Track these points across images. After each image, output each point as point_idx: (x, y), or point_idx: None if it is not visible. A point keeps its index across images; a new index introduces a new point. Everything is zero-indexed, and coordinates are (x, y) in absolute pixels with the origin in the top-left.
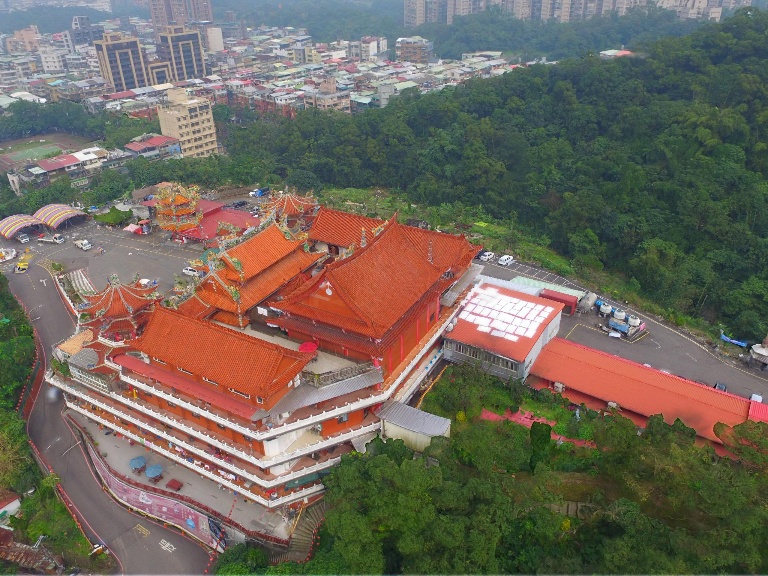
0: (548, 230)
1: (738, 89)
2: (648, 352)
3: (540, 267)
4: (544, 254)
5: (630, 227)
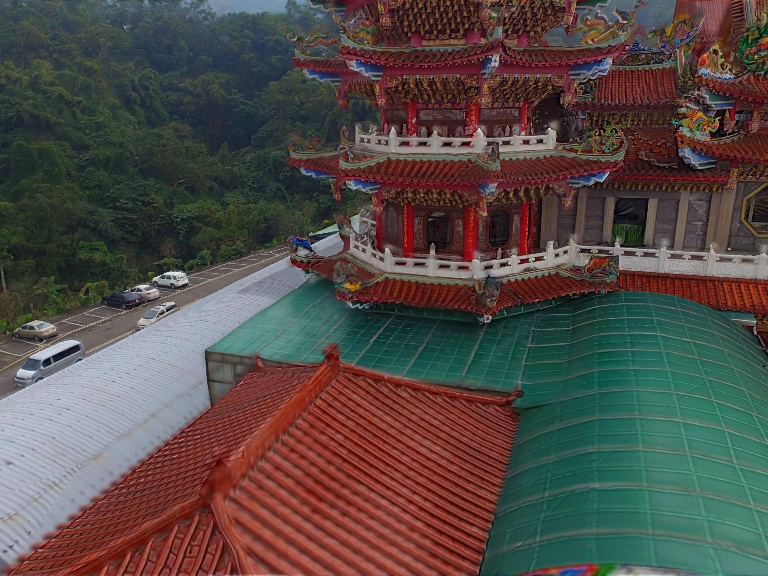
0: (8, 284)
1: (25, 42)
2: None
3: (204, 267)
4: (107, 289)
5: (131, 212)
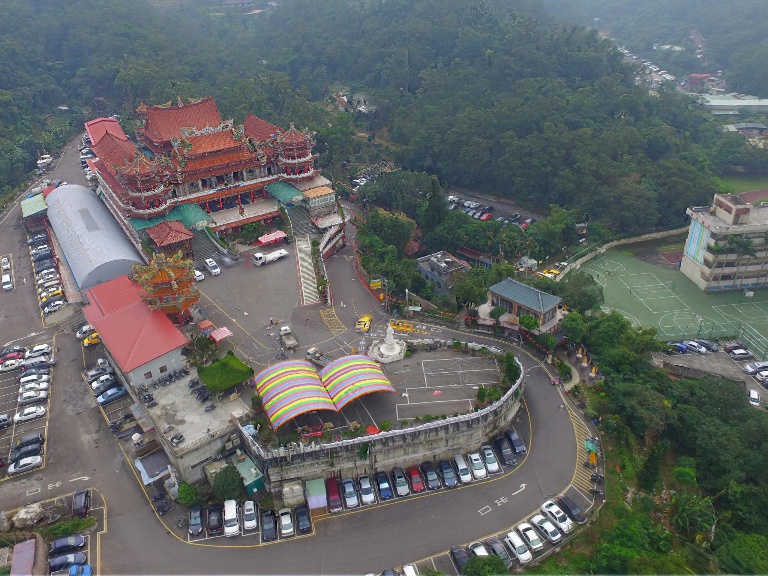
0: None
1: None
2: (70, 178)
3: None
4: None
5: None
